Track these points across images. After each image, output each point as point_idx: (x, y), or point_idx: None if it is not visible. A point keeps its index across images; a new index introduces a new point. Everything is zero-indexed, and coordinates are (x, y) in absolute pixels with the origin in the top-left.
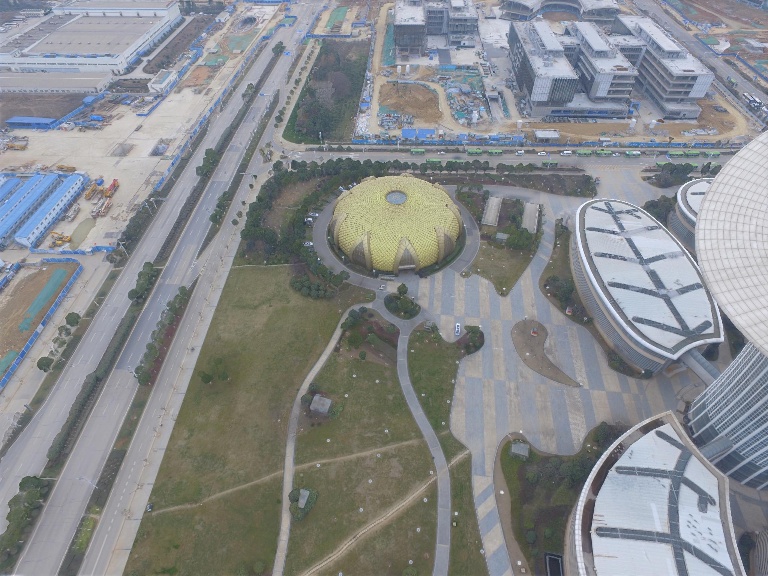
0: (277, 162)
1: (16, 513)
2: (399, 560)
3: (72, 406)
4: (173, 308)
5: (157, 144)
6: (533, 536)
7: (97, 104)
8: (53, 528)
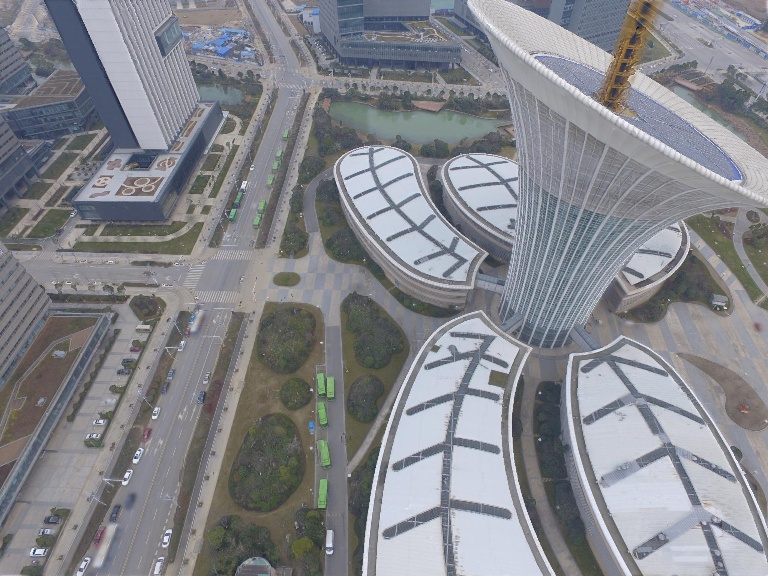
0: None
1: None
2: None
3: None
4: None
5: None
6: (695, 256)
7: None
8: None
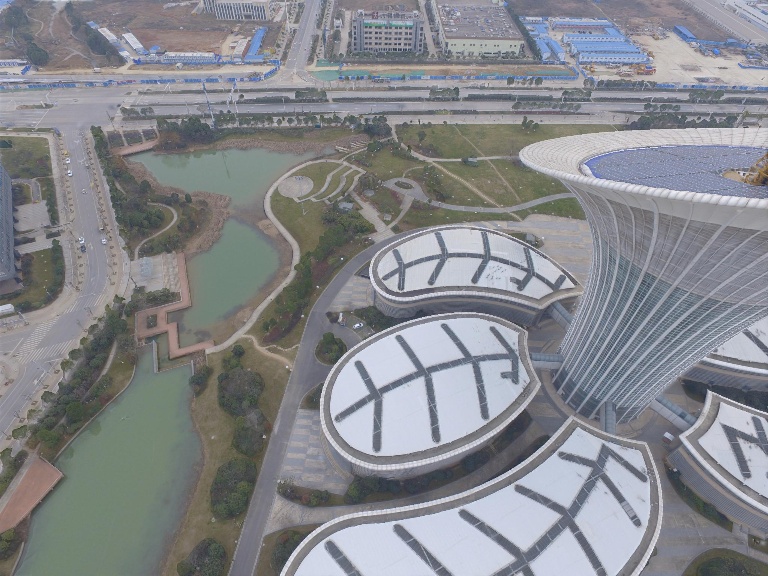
0: (733, 116)
1: (445, 90)
2: (453, 193)
3: (493, 94)
4: (563, 104)
5: (711, 78)
6: None
7: (733, 48)
8: (442, 106)
